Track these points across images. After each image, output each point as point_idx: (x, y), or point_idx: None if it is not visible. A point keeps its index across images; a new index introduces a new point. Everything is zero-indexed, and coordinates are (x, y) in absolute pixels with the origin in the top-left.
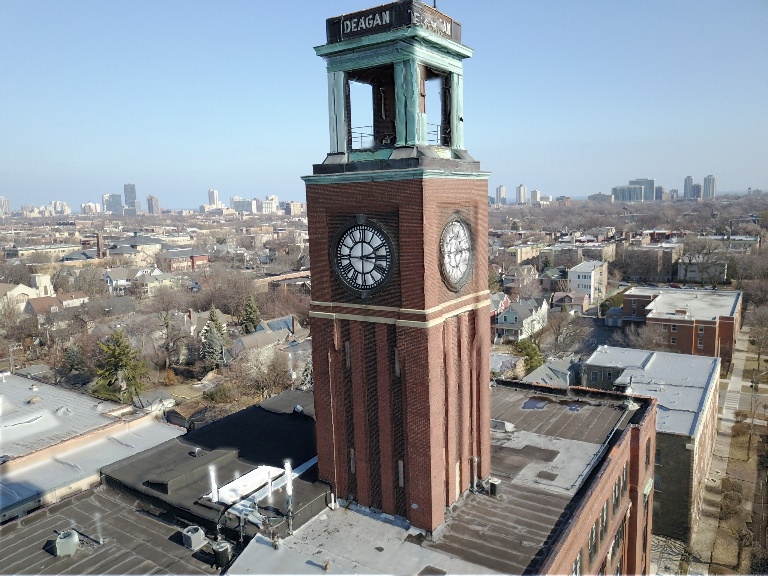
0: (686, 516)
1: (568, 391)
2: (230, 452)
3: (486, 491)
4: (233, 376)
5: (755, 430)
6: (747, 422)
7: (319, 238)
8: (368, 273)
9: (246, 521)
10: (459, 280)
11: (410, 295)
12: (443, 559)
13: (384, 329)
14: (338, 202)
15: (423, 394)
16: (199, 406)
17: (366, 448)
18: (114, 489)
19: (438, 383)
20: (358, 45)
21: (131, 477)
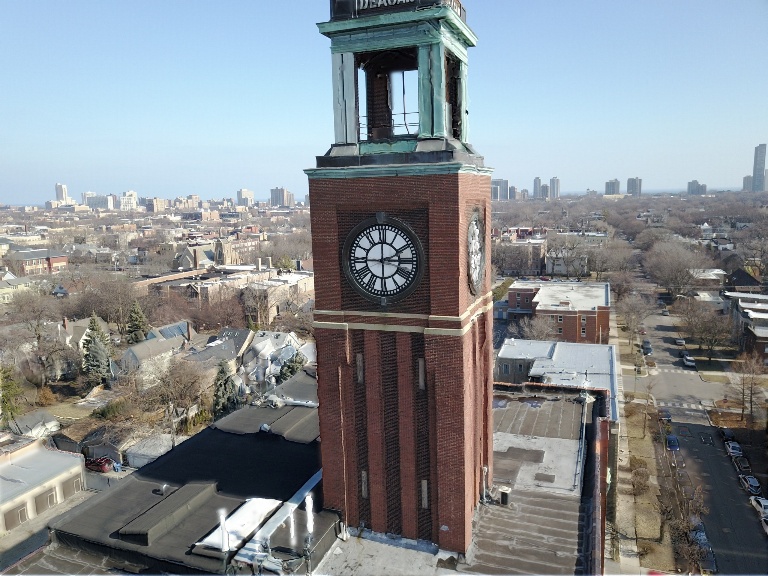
0: (611, 496)
1: (523, 388)
2: (208, 486)
3: (496, 501)
4: (125, 390)
5: (643, 409)
6: (634, 402)
7: (327, 239)
8: (389, 277)
9: (261, 568)
10: (475, 282)
11: (442, 300)
12: None
13: (407, 338)
14: (353, 199)
15: (456, 407)
16: (92, 427)
17: (383, 469)
18: (69, 546)
19: (468, 394)
20: (375, 24)
21: (91, 529)
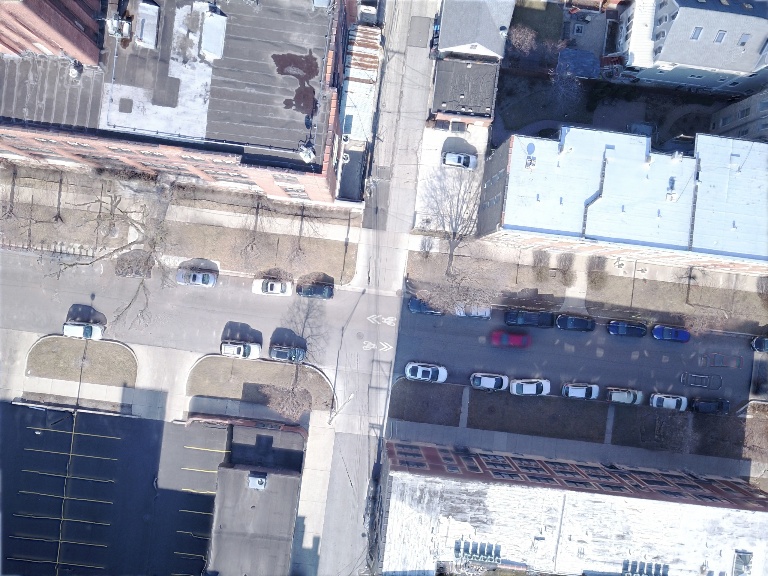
0: None
1: None
2: None
3: None
4: None
5: None
6: None
7: None
8: None
9: None
10: None
11: None
12: None
13: None
14: None
15: None
16: None
17: None
18: None
19: None
20: None
21: None
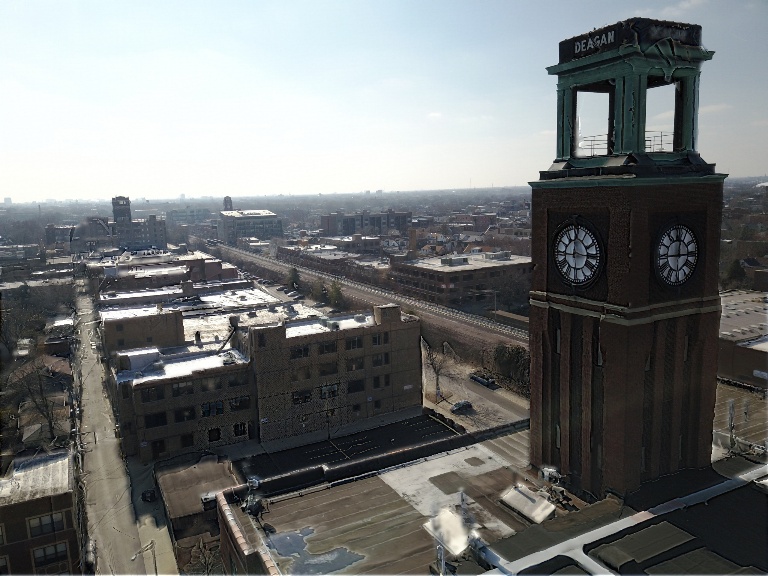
0: None
1: None
2: None
3: None
4: None
5: None
6: None
7: None
8: None
9: None
10: None
11: None
12: None
13: None
14: None
15: None
16: None
17: None
18: None
19: None
20: None
21: None
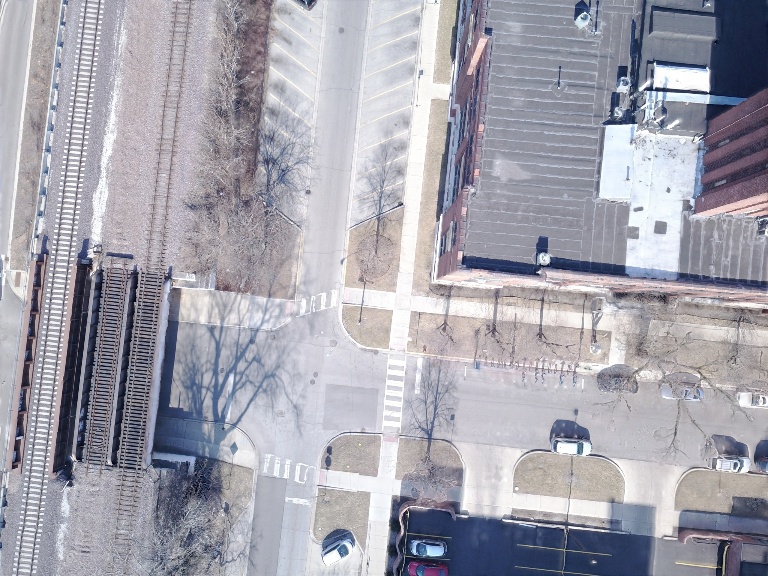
0: None
1: None
2: (712, 36)
3: (762, 227)
4: None
5: None
6: None
7: None
8: None
9: (644, 110)
10: None
11: None
12: (676, 228)
13: None
14: None
15: (752, 192)
16: None
17: (728, 153)
18: None
19: None
20: None
21: None
